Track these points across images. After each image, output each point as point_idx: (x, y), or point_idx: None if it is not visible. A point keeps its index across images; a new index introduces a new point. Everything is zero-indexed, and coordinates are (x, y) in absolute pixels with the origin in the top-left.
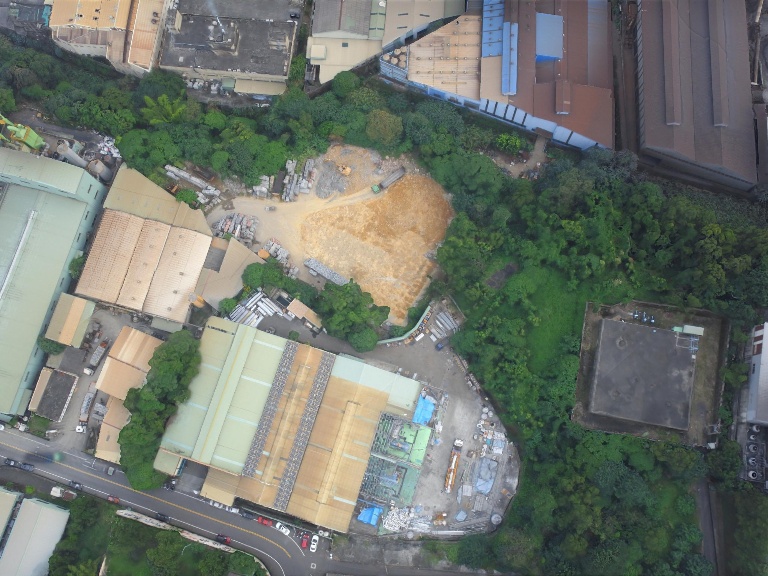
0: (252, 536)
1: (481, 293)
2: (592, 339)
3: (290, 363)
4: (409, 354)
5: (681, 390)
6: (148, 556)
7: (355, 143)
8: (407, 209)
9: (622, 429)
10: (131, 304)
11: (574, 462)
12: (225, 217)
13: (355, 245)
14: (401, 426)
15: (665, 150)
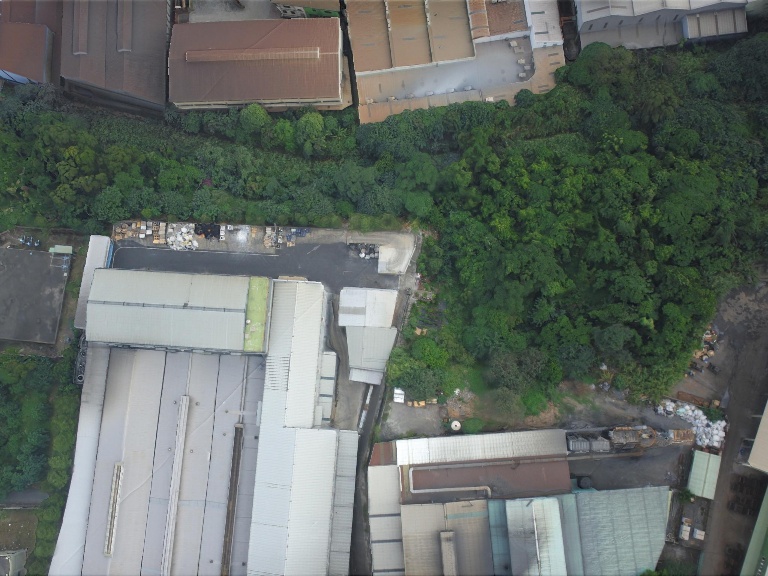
0: None
1: None
2: None
3: None
4: None
5: (52, 307)
6: None
7: None
8: None
9: (2, 348)
10: None
11: None
12: None
13: None
14: None
15: (76, 80)
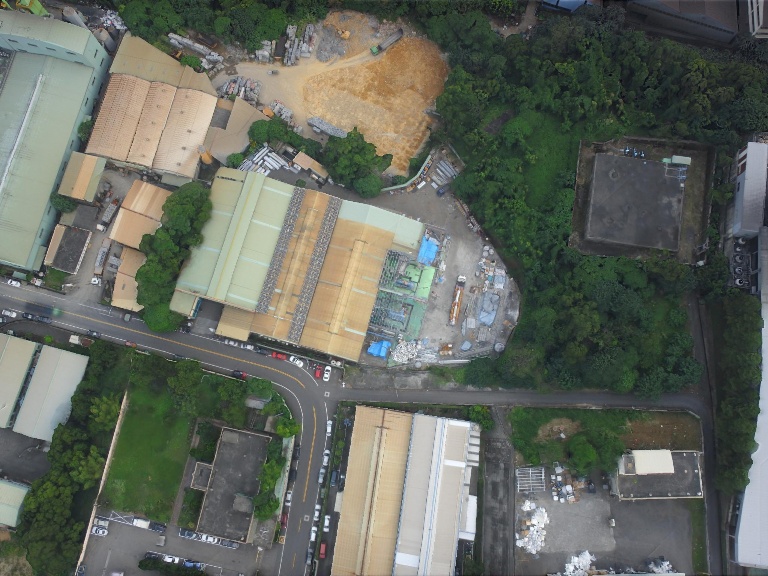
0: (267, 370)
1: (479, 139)
2: (586, 174)
3: (298, 207)
4: (412, 201)
5: (671, 216)
6: (169, 383)
7: (353, 7)
8: (405, 69)
9: (616, 254)
10: (141, 161)
11: (572, 282)
12: (229, 80)
13: (356, 104)
14: (407, 263)
15: (651, 2)
